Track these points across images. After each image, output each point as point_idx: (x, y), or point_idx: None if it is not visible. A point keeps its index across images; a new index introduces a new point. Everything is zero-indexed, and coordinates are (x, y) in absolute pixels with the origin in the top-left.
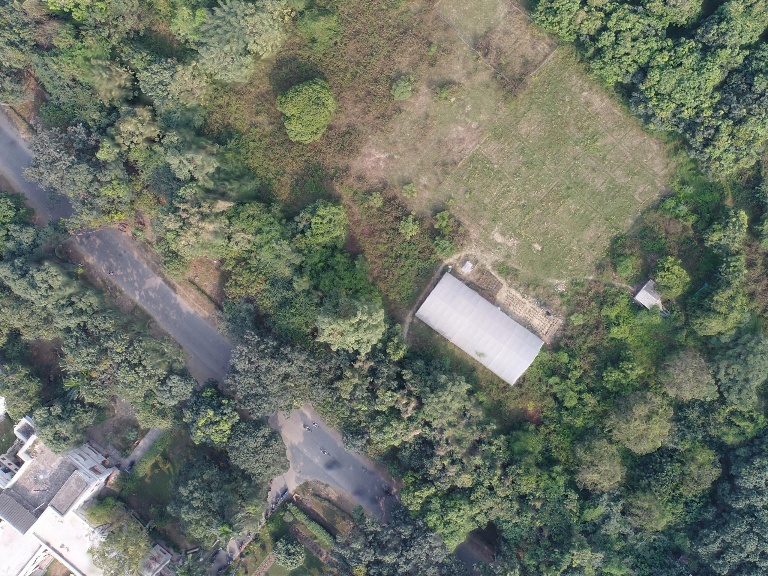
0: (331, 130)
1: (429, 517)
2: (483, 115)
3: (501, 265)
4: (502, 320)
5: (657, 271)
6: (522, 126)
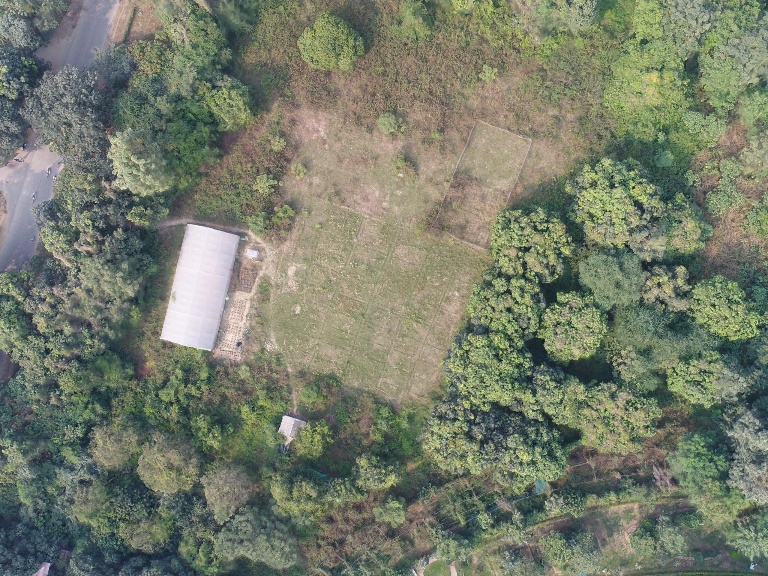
0: (325, 75)
1: None
2: (398, 209)
3: (267, 283)
4: (214, 303)
5: None
6: (403, 248)
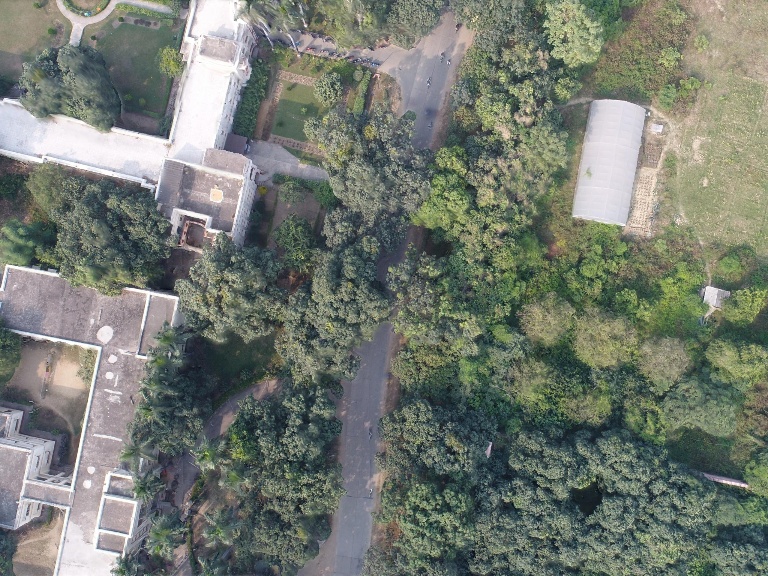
0: None
1: (441, 177)
2: None
3: (674, 157)
4: (629, 177)
5: (747, 287)
6: None
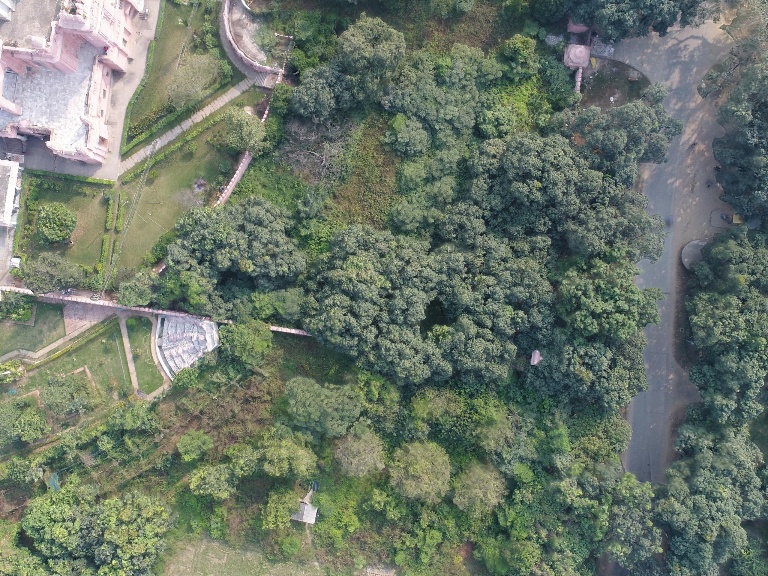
0: None
1: None
2: None
3: None
4: None
5: None
6: None
